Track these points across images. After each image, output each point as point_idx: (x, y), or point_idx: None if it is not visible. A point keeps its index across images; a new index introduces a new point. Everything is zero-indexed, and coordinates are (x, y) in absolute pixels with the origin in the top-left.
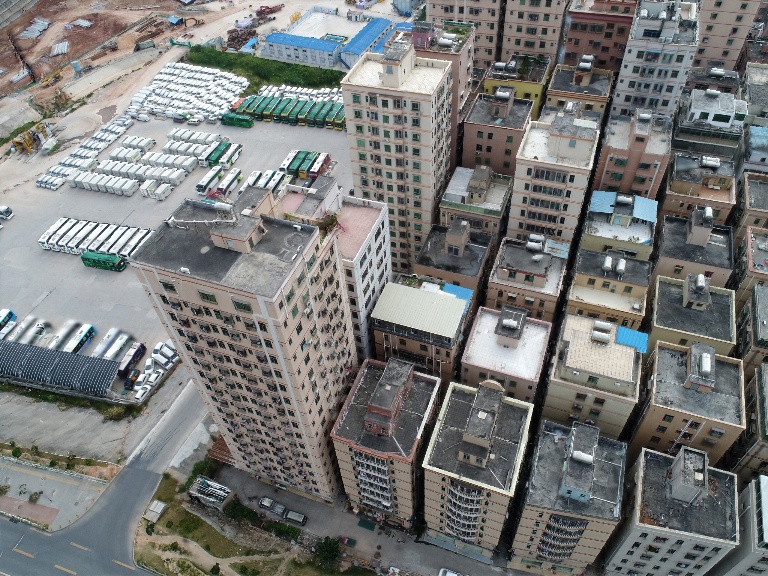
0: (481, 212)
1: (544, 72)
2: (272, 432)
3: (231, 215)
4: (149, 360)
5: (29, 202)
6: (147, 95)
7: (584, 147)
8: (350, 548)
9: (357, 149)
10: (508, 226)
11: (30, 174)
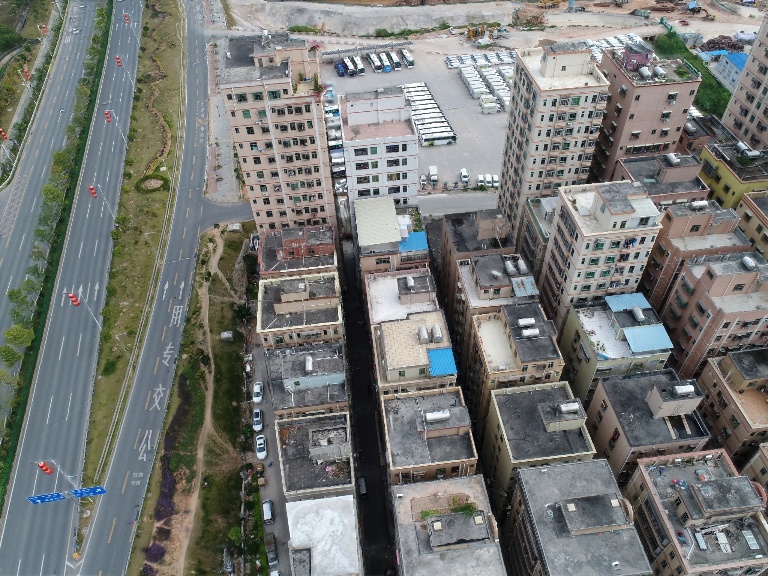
0: (539, 230)
1: (762, 176)
2: None
3: (264, 41)
4: (344, 180)
5: (429, 66)
6: None
7: (608, 218)
8: None
9: (510, 117)
10: (545, 257)
11: (453, 52)
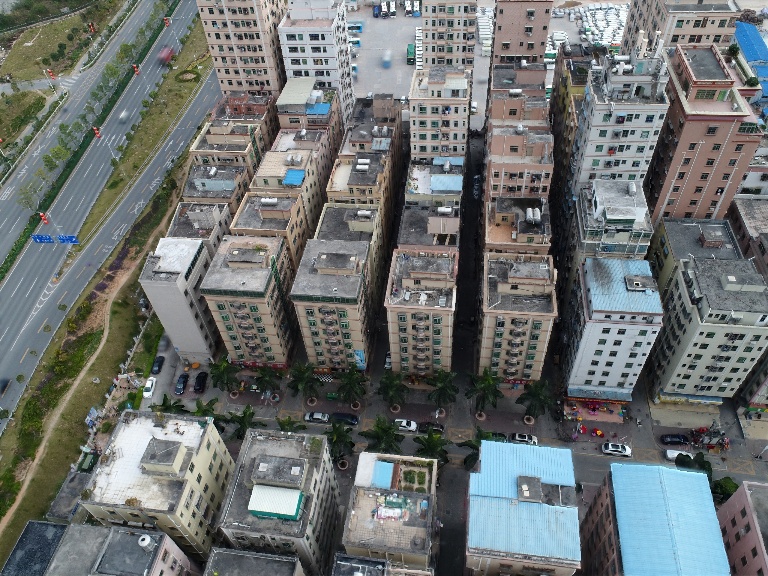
0: None
1: None
2: None
3: None
4: None
5: None
6: (602, 8)
7: None
8: None
9: None
10: None
11: (482, 5)
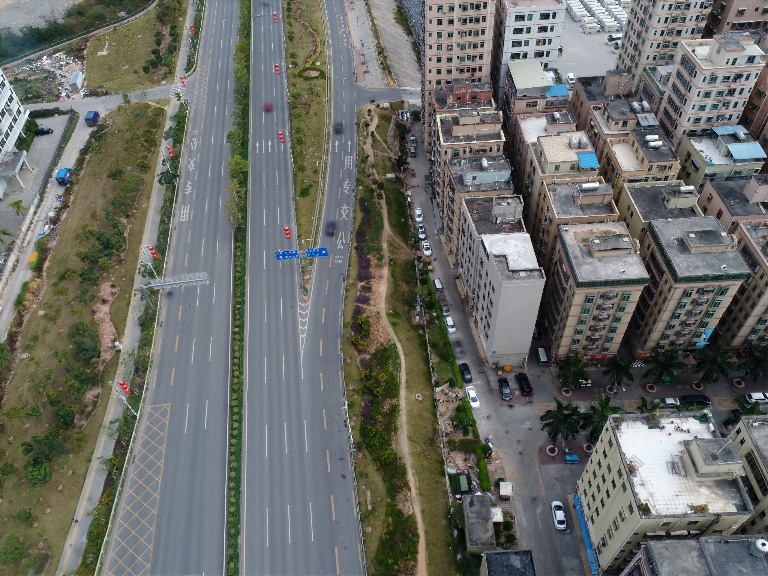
0: None
1: None
2: (423, 74)
3: None
4: None
5: None
6: None
7: None
8: (411, 176)
9: (633, 3)
10: (660, 107)
11: None
